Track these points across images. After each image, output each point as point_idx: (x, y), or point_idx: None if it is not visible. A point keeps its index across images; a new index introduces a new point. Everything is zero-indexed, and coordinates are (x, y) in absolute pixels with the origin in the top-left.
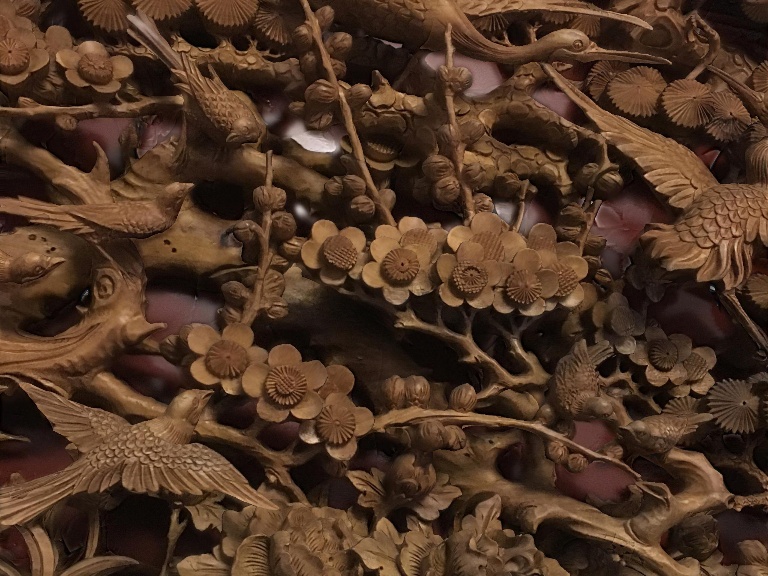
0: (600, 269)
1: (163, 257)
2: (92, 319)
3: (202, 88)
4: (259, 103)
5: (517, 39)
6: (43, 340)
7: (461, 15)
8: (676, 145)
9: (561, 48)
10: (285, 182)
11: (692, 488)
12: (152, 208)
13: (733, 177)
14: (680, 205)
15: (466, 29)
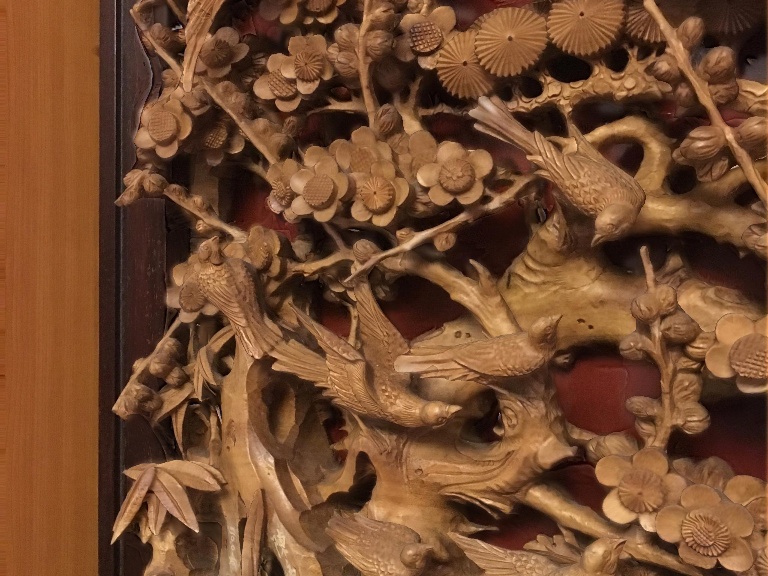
0: None
1: (582, 335)
2: (507, 445)
3: (560, 175)
4: (658, 119)
5: None
6: (475, 460)
7: None
8: None
9: None
10: (698, 229)
11: None
12: (525, 346)
13: None
14: None
15: None
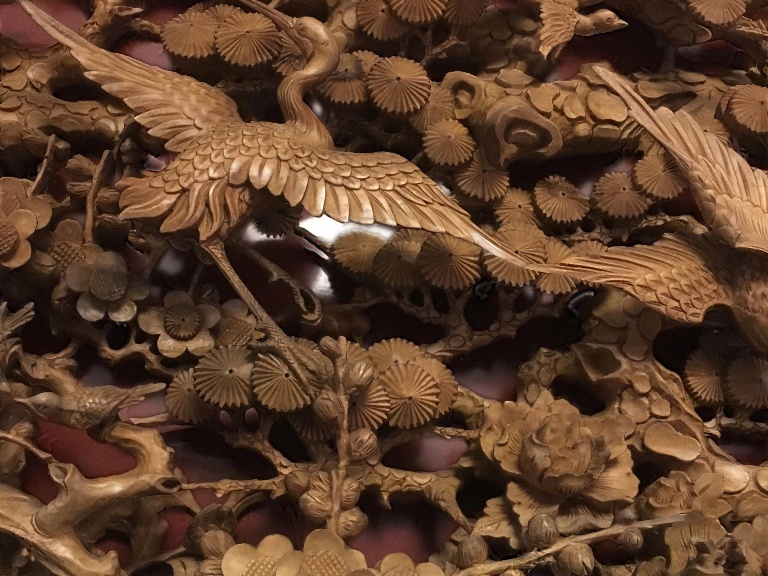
0: (133, 229)
1: None
2: None
3: None
4: None
5: None
6: None
7: None
8: (188, 83)
9: None
10: None
11: None
12: None
13: (322, 121)
14: (179, 149)
15: None
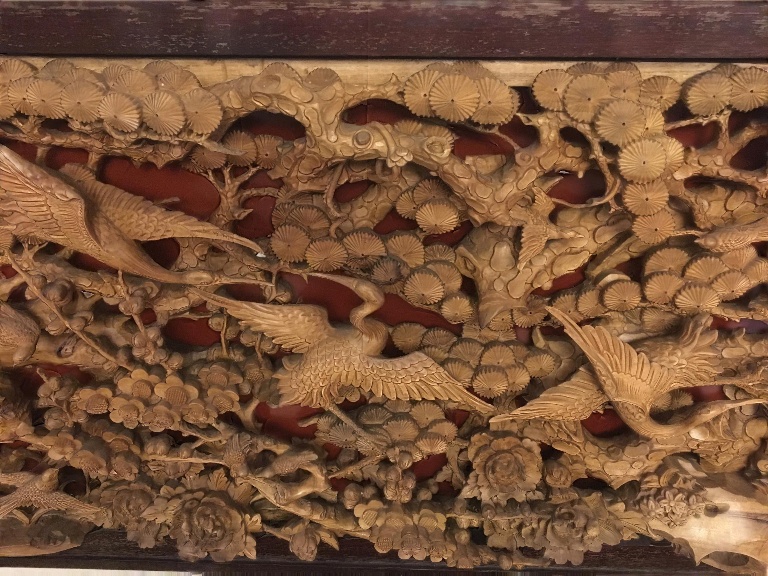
0: None
1: (34, 361)
2: (1, 427)
3: None
4: None
5: None
6: None
7: (127, 261)
8: (297, 315)
9: (194, 284)
10: None
11: (309, 481)
12: None
13: None
14: (300, 352)
15: (133, 269)
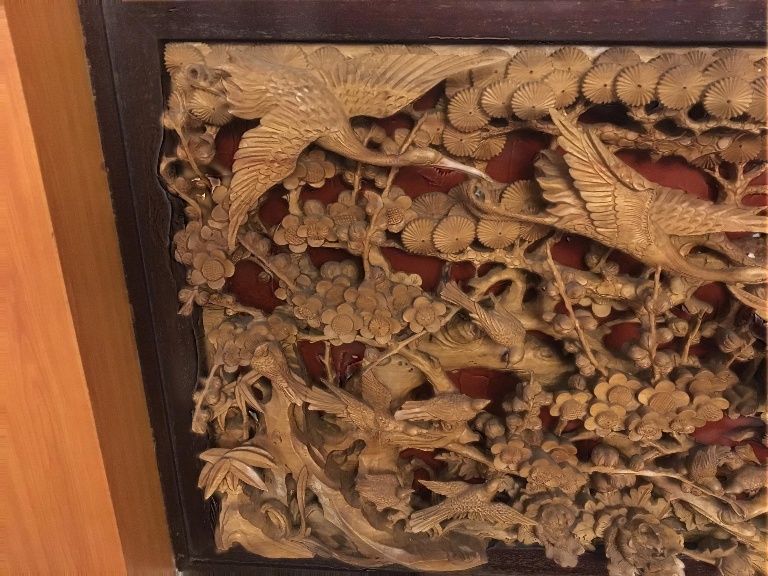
0: None
1: (469, 365)
2: (442, 433)
3: (489, 328)
4: None
5: (727, 168)
6: None
7: (670, 256)
8: None
9: (745, 282)
10: (539, 330)
11: (764, 499)
12: (469, 411)
13: None
14: None
15: (672, 265)
